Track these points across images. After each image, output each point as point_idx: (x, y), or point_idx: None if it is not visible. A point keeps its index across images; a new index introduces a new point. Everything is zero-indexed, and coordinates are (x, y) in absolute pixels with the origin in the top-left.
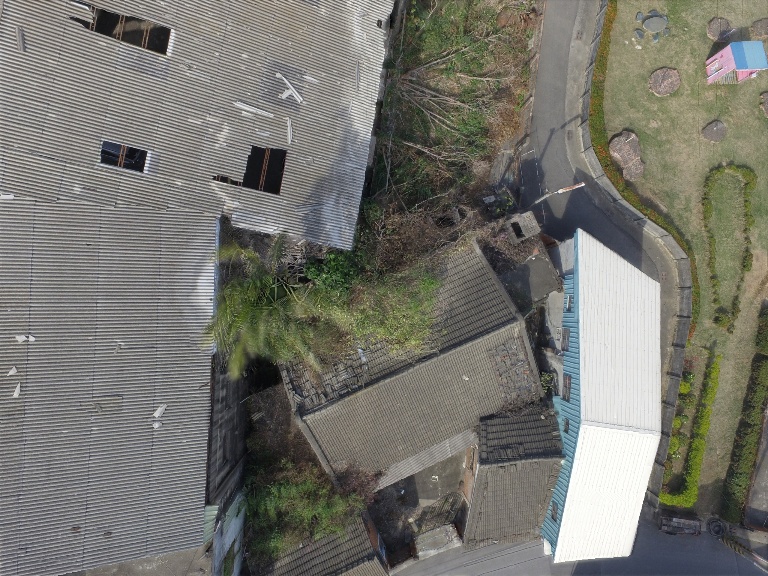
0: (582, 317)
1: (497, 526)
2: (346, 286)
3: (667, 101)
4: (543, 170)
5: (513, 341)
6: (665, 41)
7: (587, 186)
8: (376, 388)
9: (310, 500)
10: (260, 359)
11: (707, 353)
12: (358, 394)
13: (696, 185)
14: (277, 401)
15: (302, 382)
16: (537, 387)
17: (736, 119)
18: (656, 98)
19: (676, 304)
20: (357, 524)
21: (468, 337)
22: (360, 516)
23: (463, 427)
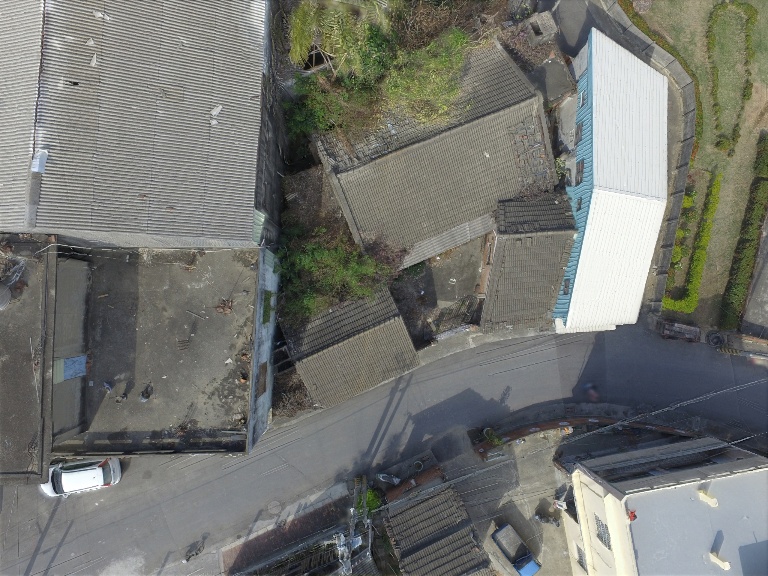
0: (595, 101)
1: (512, 308)
2: (379, 54)
3: None
4: None
5: (531, 120)
6: None
7: (599, 18)
8: (405, 154)
9: (341, 263)
10: (292, 155)
11: (709, 175)
12: (388, 157)
13: (701, 20)
14: (309, 183)
15: (335, 151)
16: (552, 174)
17: None
18: None
19: (680, 131)
20: (383, 292)
21: (490, 111)
22: (386, 285)
23: (482, 210)
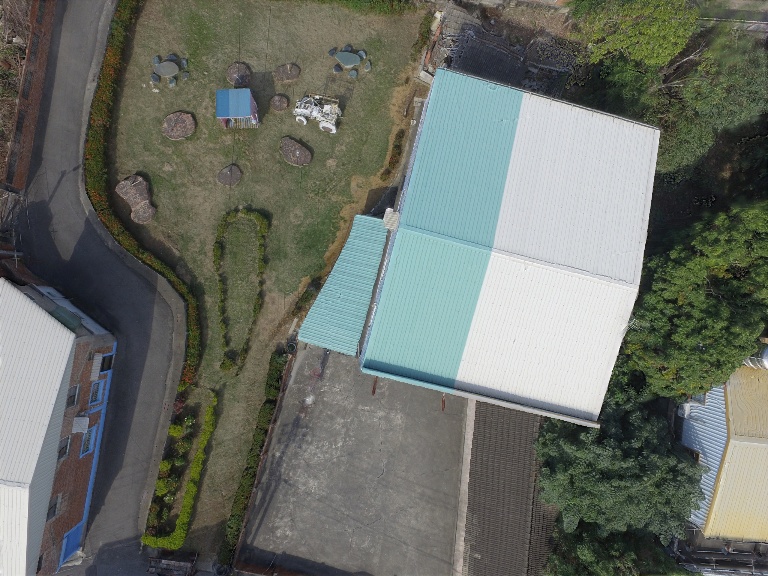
0: None
1: None
2: None
3: (183, 144)
4: (52, 212)
5: None
6: (184, 85)
7: (101, 228)
8: None
9: None
10: None
11: (213, 395)
12: None
13: (211, 228)
14: None
15: None
16: None
17: (254, 163)
18: (171, 141)
19: None
20: None
21: None
22: None
23: None
